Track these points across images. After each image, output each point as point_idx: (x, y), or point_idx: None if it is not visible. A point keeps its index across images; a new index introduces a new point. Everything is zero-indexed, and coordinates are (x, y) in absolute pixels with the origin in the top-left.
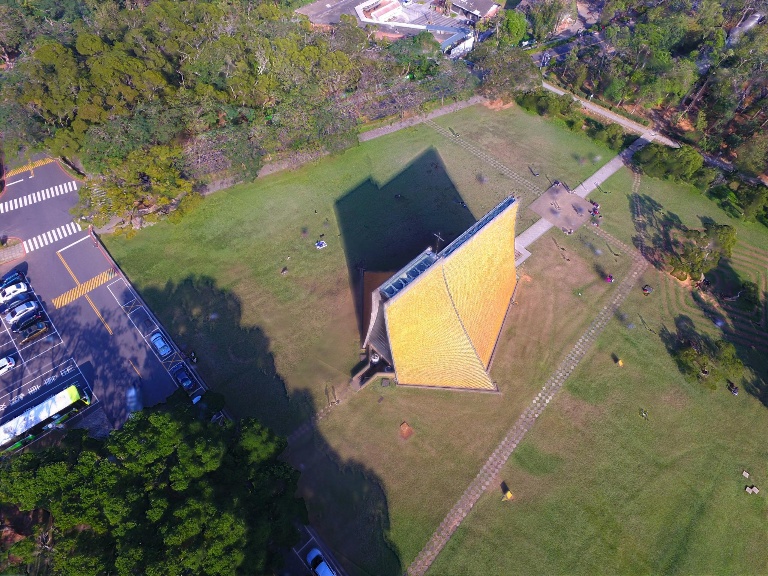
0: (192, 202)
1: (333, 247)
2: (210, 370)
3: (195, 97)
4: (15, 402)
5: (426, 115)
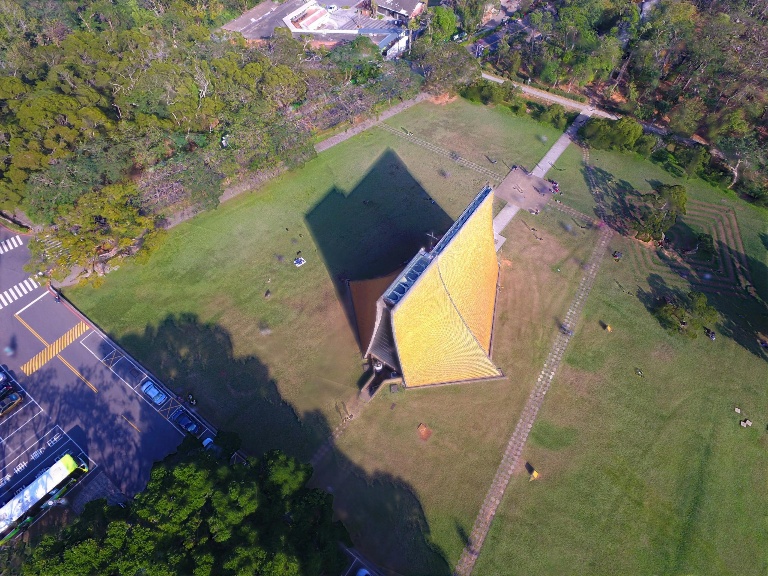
0: (157, 239)
1: (312, 262)
2: (212, 410)
3: (139, 129)
4: (2, 485)
5: (377, 118)
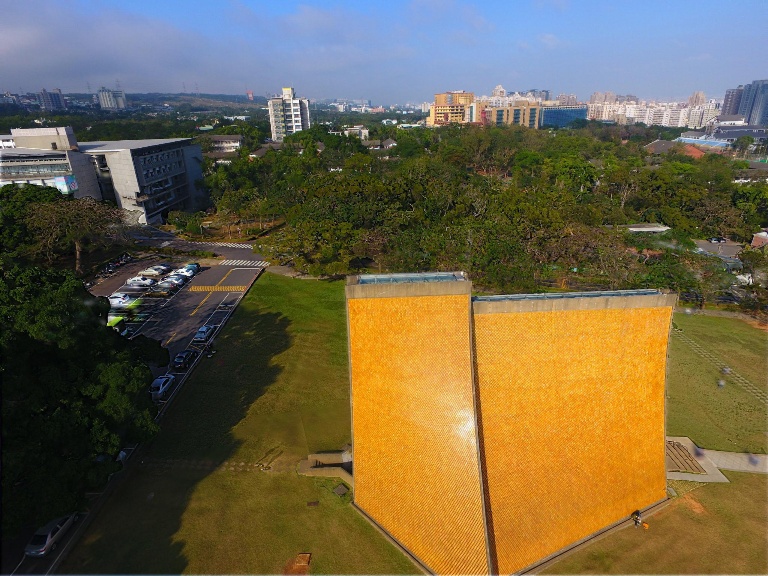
0: (337, 265)
1: None
2: (209, 368)
3: None
4: None
5: None
